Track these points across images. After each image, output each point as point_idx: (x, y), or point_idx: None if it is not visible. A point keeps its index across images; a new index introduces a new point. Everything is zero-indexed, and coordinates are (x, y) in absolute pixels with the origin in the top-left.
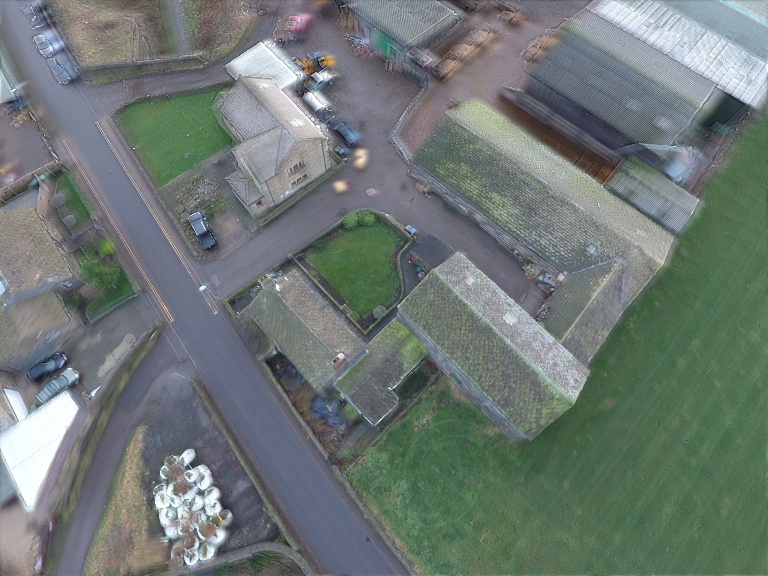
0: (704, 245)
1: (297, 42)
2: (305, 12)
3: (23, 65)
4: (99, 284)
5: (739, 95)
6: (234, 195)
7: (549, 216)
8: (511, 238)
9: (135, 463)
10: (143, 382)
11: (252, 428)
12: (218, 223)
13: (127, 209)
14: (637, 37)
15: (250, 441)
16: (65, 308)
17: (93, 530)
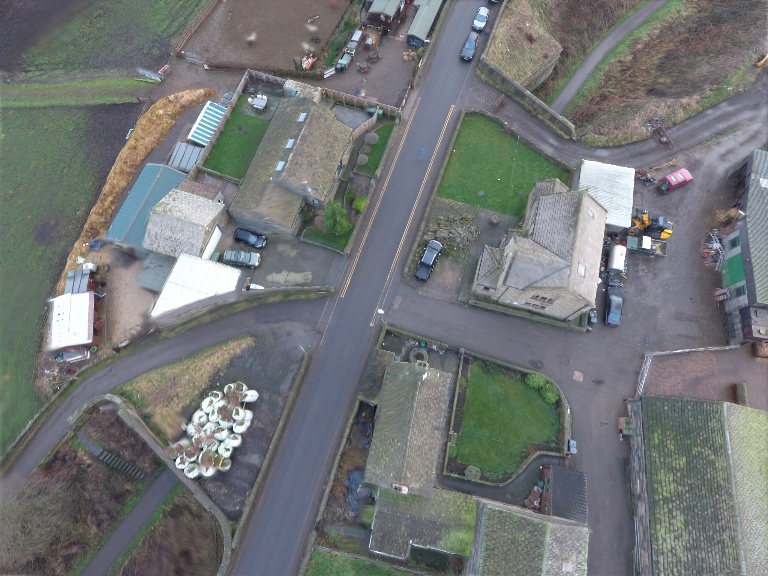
0: None
1: (665, 194)
2: (702, 176)
3: (455, 19)
4: (330, 226)
5: None
6: (478, 259)
7: None
8: (649, 568)
9: (223, 358)
10: (283, 313)
11: (302, 430)
12: (445, 265)
13: (403, 188)
14: None
15: (292, 437)
16: (298, 214)
17: (164, 363)
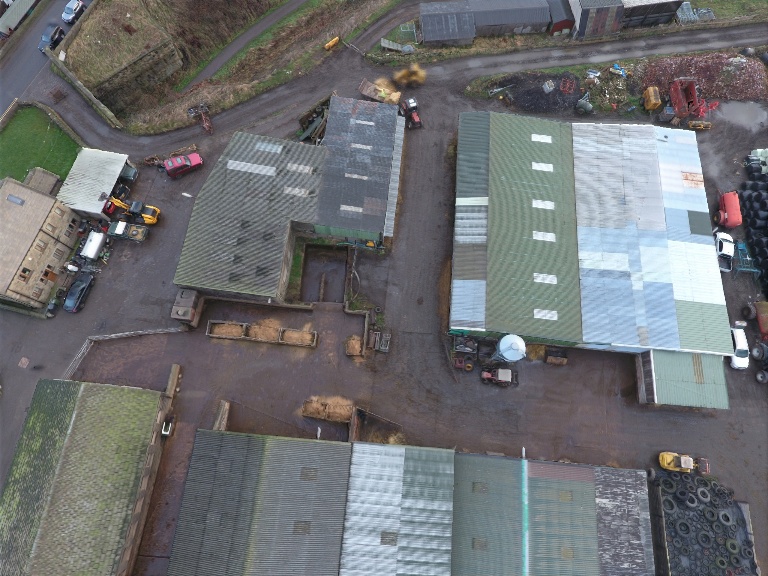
0: None
1: (175, 179)
2: None
3: (51, 12)
4: None
5: None
6: None
7: None
8: None
9: None
10: None
11: None
12: None
13: None
14: (346, 539)
15: None
16: None
17: None
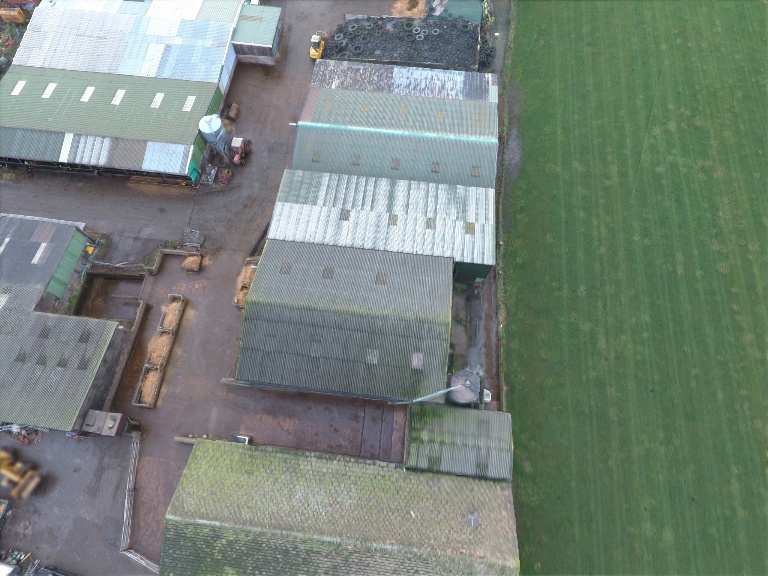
0: (544, 442)
1: None
2: None
3: None
4: None
5: (481, 257)
6: None
7: (365, 575)
8: None
9: None
10: None
11: None
12: None
13: None
14: (342, 244)
15: None
16: None
17: None
